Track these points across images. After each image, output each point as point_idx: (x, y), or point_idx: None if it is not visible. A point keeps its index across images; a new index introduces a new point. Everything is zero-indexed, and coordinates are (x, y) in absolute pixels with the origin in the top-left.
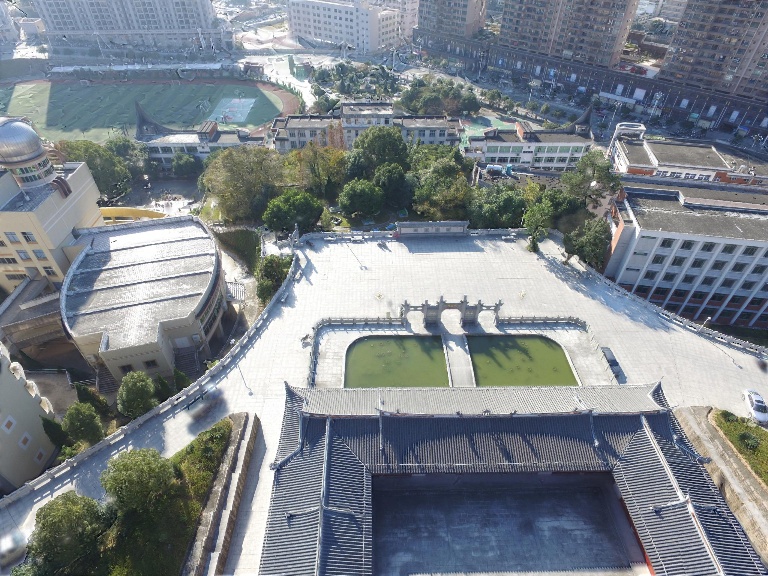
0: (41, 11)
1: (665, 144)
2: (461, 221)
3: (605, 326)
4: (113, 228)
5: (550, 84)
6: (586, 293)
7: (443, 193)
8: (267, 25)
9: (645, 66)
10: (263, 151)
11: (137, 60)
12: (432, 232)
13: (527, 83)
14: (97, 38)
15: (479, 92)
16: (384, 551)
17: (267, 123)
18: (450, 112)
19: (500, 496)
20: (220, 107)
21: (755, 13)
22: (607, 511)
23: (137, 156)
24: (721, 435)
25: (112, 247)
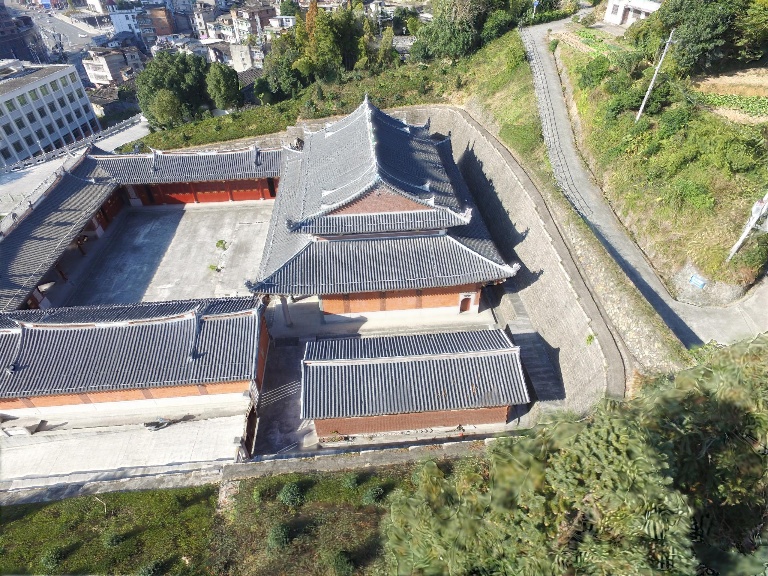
0: None
1: None
2: None
3: None
4: None
5: None
6: None
7: None
8: None
9: None
10: None
11: None
12: None
13: None
14: None
15: None
16: None
17: None
18: None
19: (103, 260)
20: None
21: None
22: (147, 213)
23: None
24: None
25: None
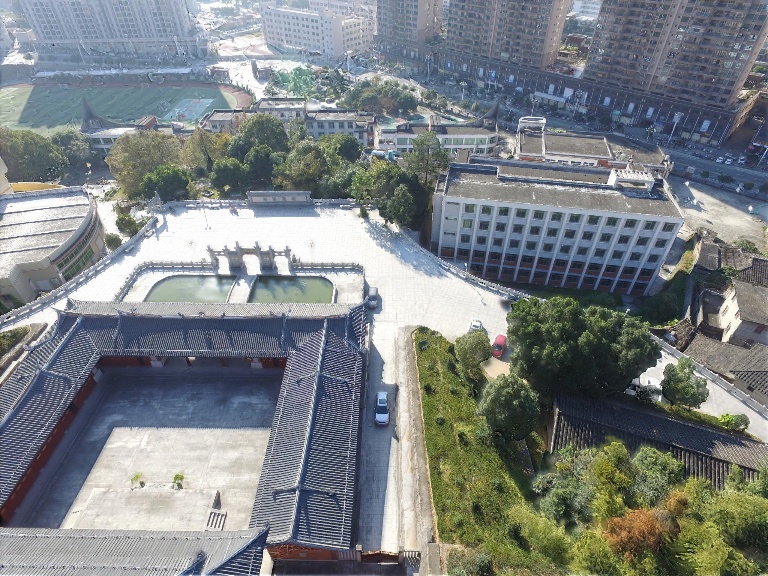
0: (32, 22)
1: (561, 136)
2: (303, 191)
3: (388, 273)
4: (12, 196)
5: (492, 85)
6: (388, 249)
7: None
8: (248, 34)
9: (573, 67)
10: (160, 136)
11: (115, 66)
12: (280, 201)
13: (459, 83)
14: (78, 46)
15: (416, 92)
16: (104, 413)
17: (199, 117)
18: (390, 111)
19: (214, 381)
20: (179, 107)
21: (659, 15)
22: None
23: (78, 146)
24: (414, 344)
25: (6, 211)
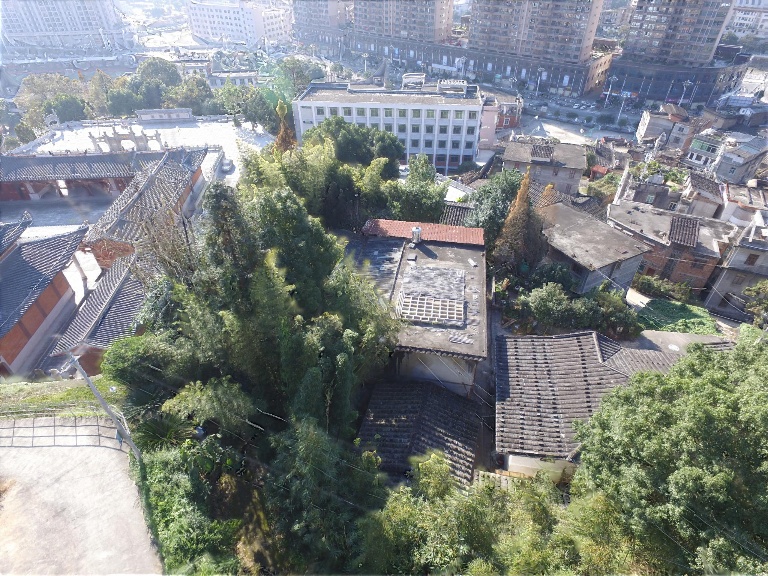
0: None
1: None
2: None
3: None
4: None
5: (397, 61)
6: (251, 142)
7: (177, 91)
8: (177, 31)
9: None
10: (65, 79)
11: (40, 55)
12: (166, 118)
13: None
14: (1, 37)
15: None
16: None
17: None
18: None
19: (81, 205)
20: None
21: None
22: None
23: None
24: None
25: None
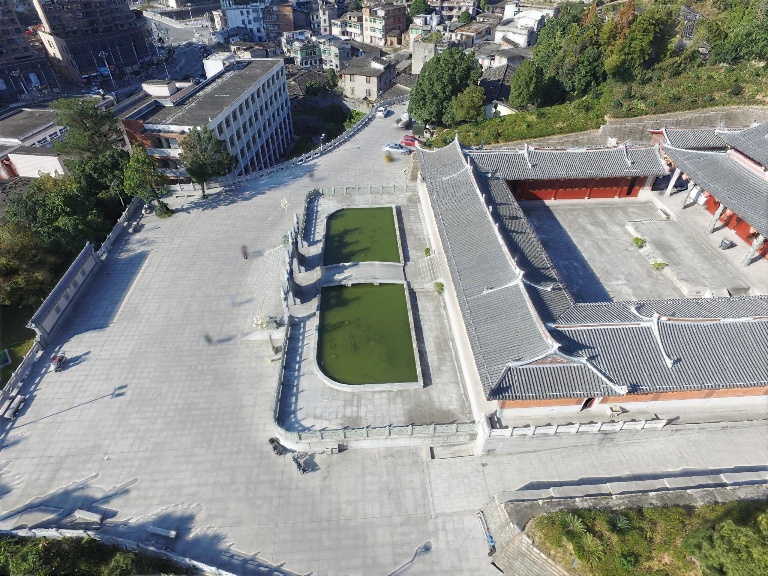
0: None
1: None
2: (84, 249)
3: (308, 190)
4: None
5: None
6: (259, 193)
7: (4, 247)
8: None
9: None
10: None
11: None
12: (73, 294)
13: None
14: None
15: None
16: None
17: None
18: None
19: None
20: None
21: None
22: None
23: None
24: None
25: None
